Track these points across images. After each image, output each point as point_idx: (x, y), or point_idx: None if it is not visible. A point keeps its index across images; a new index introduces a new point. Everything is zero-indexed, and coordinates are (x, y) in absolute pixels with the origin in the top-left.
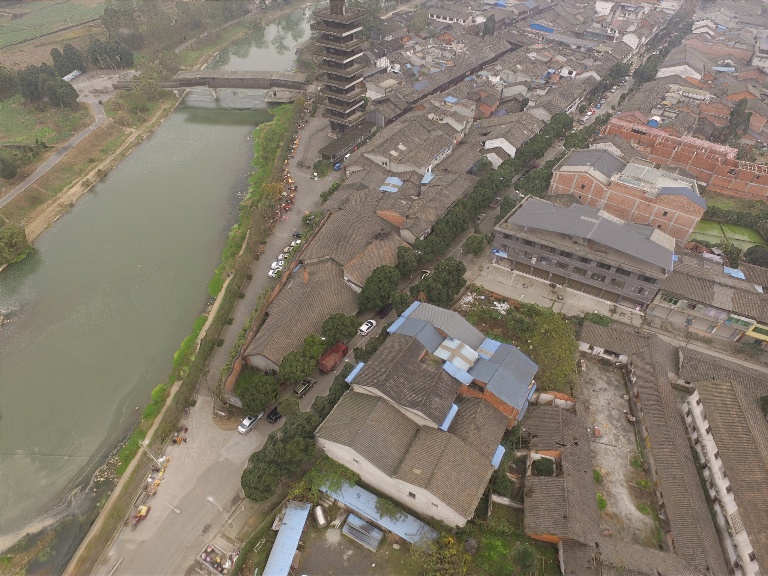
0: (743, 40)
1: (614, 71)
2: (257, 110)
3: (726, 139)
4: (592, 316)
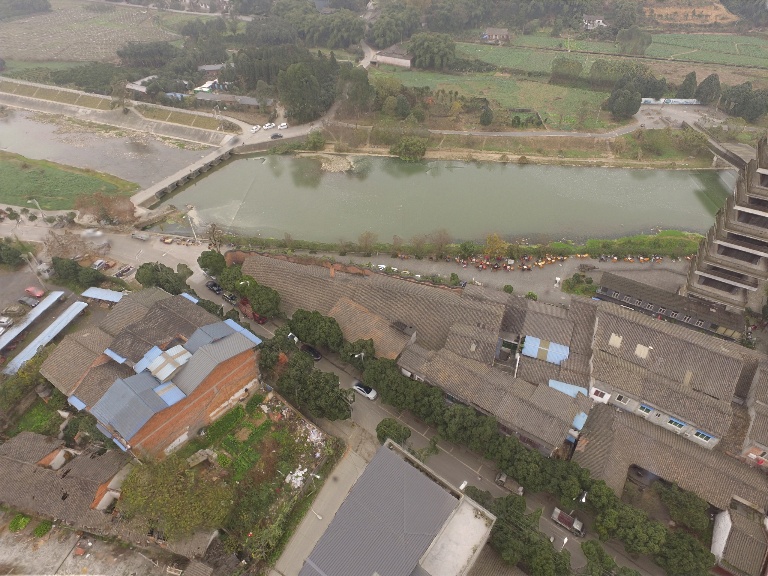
0: None
1: None
2: None
3: None
4: None
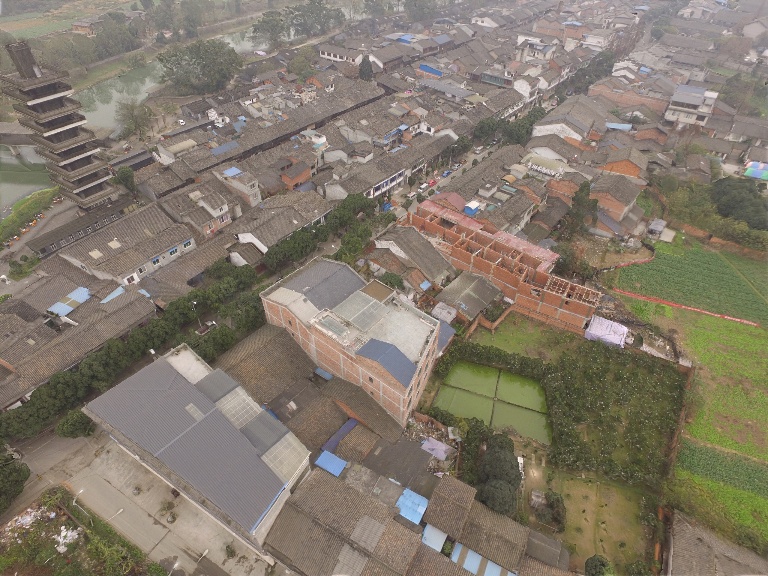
0: (659, 87)
1: (478, 129)
2: None
3: (572, 230)
4: None
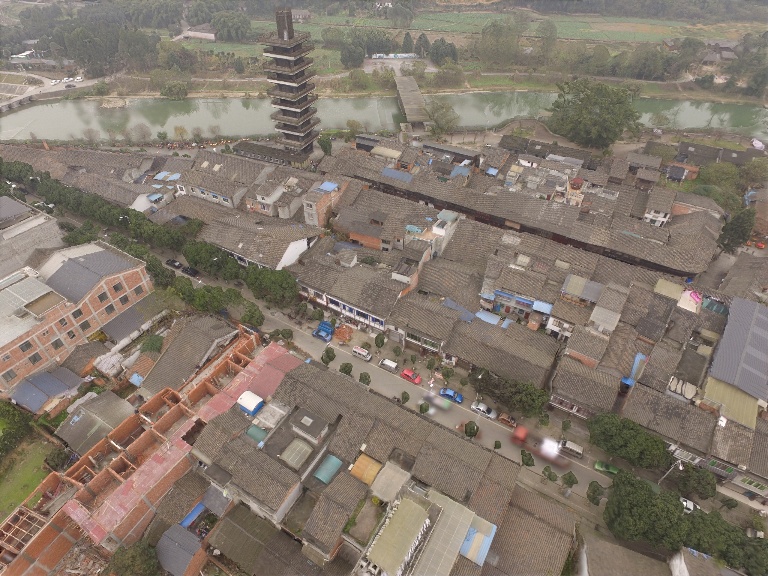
0: None
1: None
2: (383, 125)
3: None
4: None
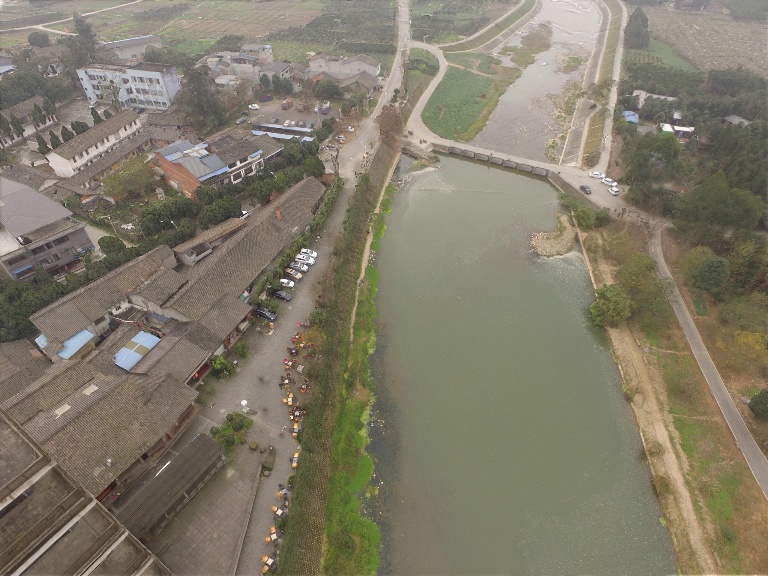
0: None
1: None
2: None
3: None
4: (73, 201)
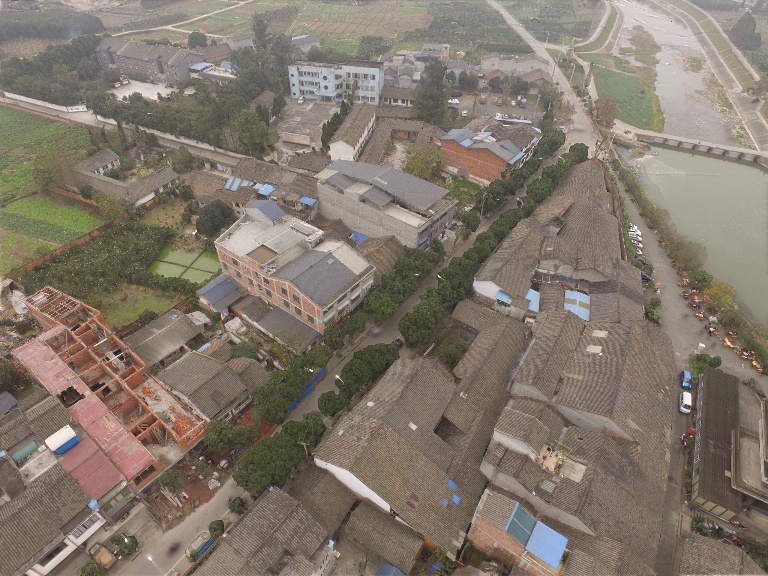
0: None
1: None
2: None
3: None
4: None
